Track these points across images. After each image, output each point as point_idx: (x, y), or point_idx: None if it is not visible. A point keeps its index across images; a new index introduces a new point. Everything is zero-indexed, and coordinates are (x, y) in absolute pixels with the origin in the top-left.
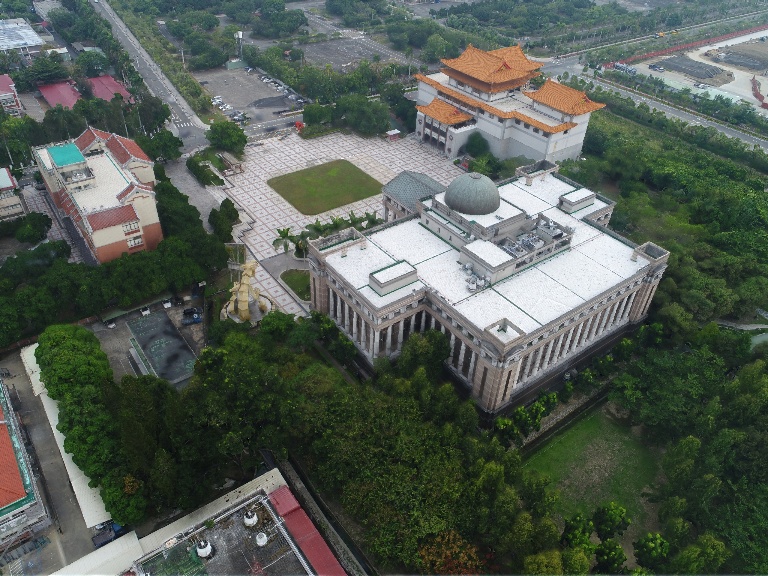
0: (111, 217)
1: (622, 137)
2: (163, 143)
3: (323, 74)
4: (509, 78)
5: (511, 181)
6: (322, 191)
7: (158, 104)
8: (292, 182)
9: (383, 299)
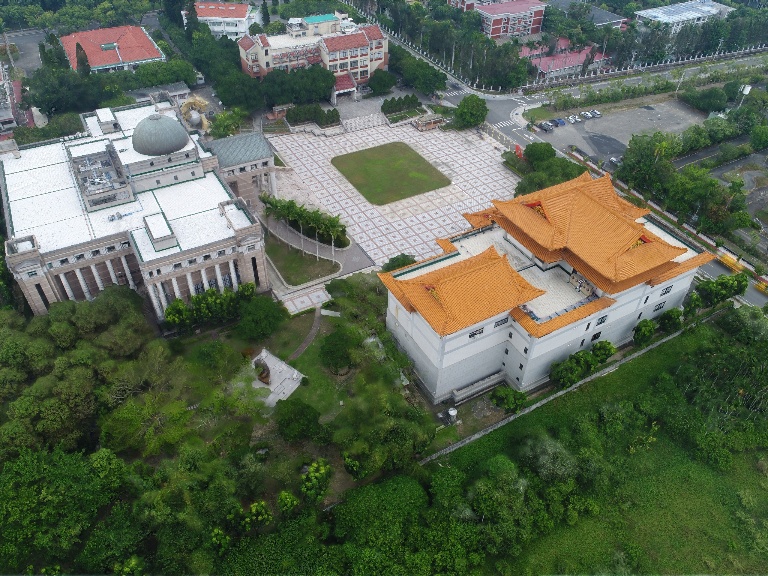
0: (246, 43)
1: (519, 485)
2: (419, 73)
3: (643, 146)
4: (523, 225)
5: (236, 203)
6: (375, 167)
7: (509, 68)
8: (396, 153)
9: (94, 120)
